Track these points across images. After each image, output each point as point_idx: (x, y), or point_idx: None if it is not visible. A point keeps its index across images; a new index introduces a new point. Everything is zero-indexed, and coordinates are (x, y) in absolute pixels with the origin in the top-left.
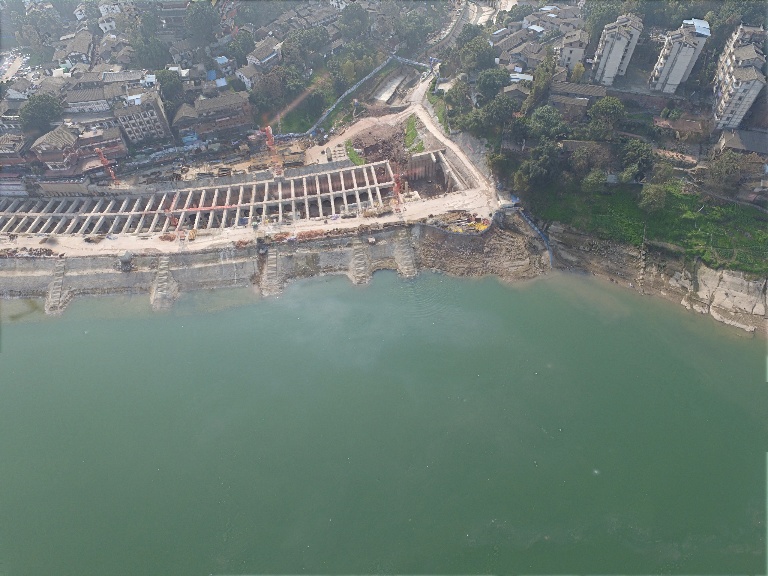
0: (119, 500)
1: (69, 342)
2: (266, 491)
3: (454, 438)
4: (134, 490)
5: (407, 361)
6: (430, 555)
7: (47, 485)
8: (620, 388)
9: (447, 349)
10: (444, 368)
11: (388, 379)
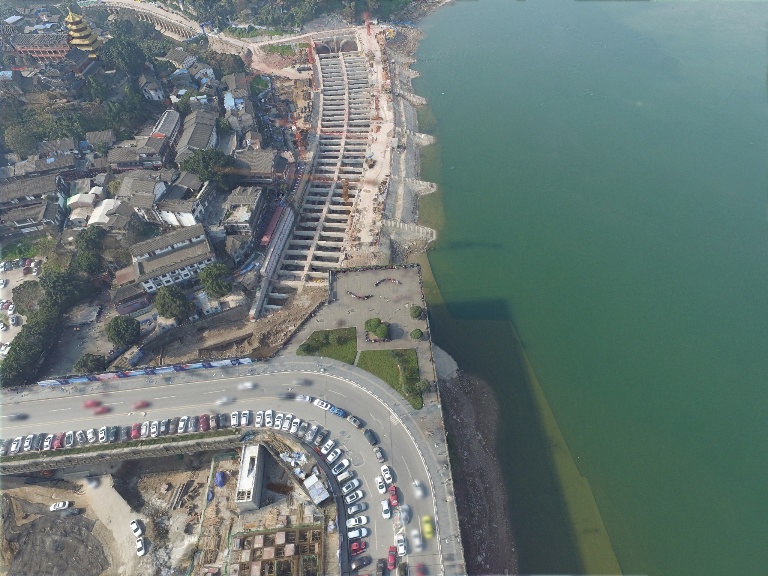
0: (559, 131)
1: (462, 172)
2: (545, 92)
3: (511, 53)
4: (553, 127)
5: (472, 62)
6: (560, 58)
7: None
8: (484, 21)
9: (465, 53)
10: None
11: (482, 67)
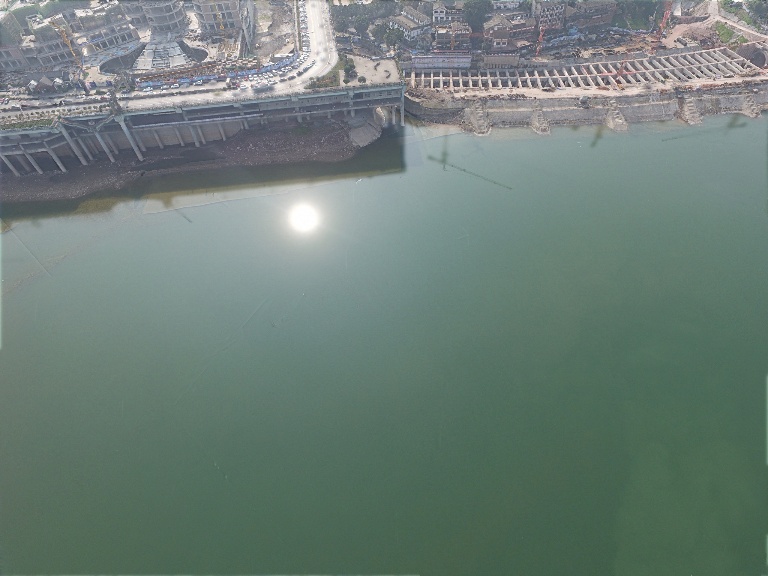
0: (693, 216)
1: (573, 147)
2: None
3: None
4: (699, 211)
5: None
6: None
7: (635, 211)
8: None
9: None
10: None
11: None
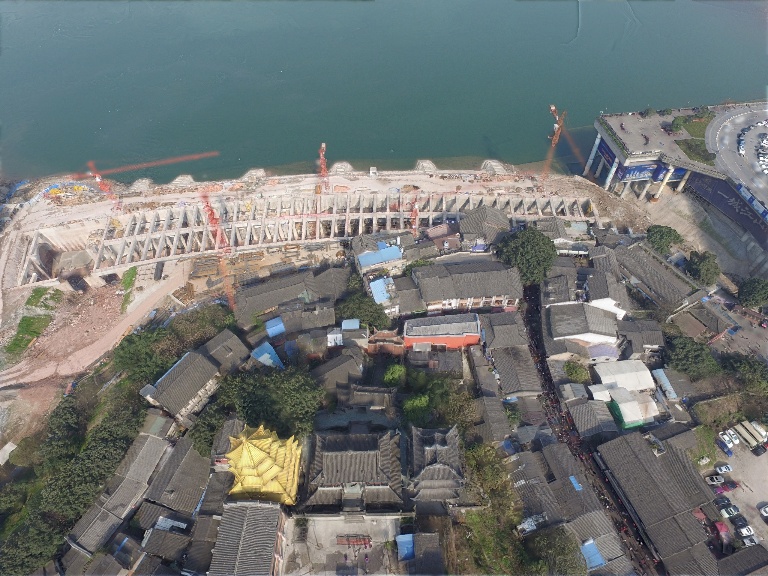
0: (336, 93)
1: (400, 145)
2: None
3: None
4: (330, 95)
5: (174, 135)
6: (197, 82)
7: None
8: (60, 124)
9: (145, 140)
10: (153, 132)
11: (190, 129)
